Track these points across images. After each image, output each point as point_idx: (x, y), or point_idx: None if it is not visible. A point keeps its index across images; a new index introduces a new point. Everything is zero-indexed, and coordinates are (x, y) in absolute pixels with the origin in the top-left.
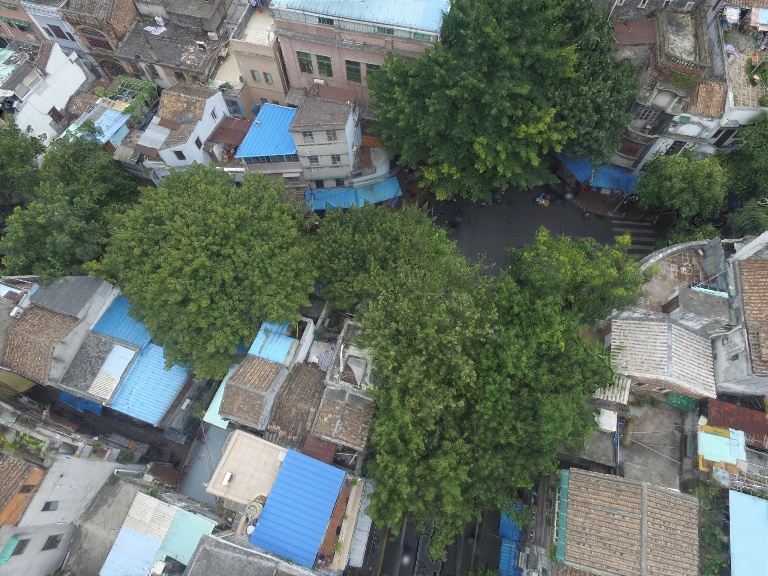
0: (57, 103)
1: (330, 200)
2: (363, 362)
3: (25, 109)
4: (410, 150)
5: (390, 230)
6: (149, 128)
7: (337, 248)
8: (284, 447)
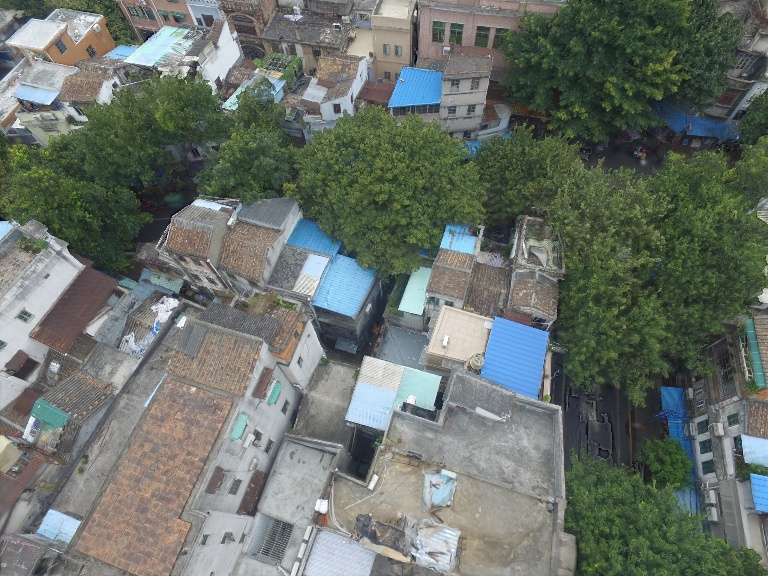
0: (221, 73)
1: None
2: (544, 250)
3: (203, 74)
4: (542, 95)
5: None
6: (310, 87)
7: (506, 163)
8: (488, 317)
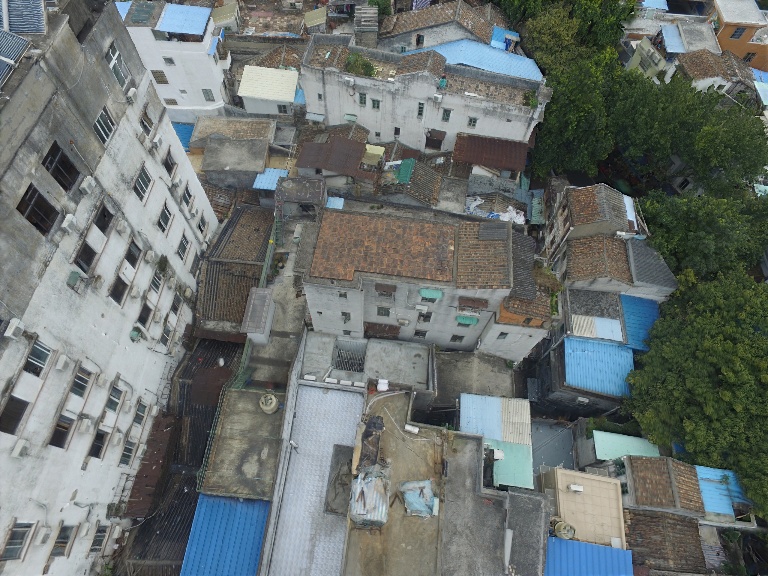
0: None
1: None
2: None
3: None
4: None
5: None
6: None
7: None
8: None
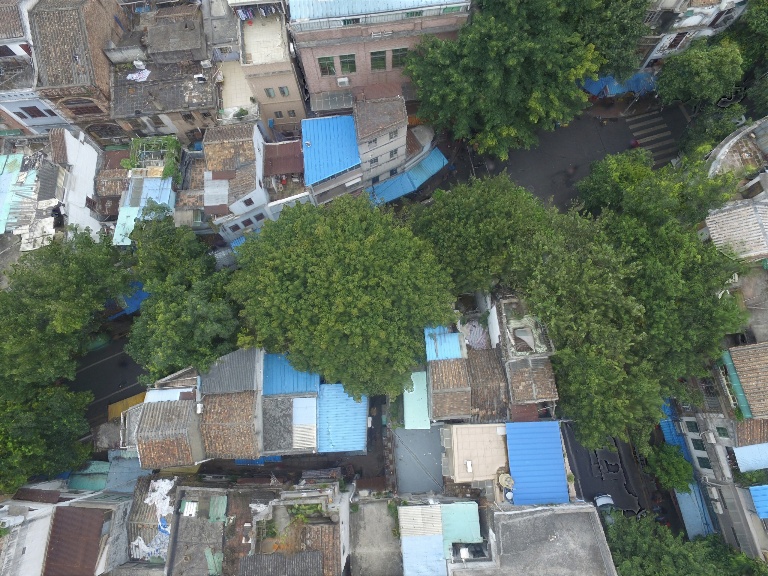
0: (87, 191)
1: (389, 191)
2: (528, 330)
3: (70, 211)
4: (466, 123)
5: None
6: (206, 186)
7: (462, 241)
8: (498, 423)
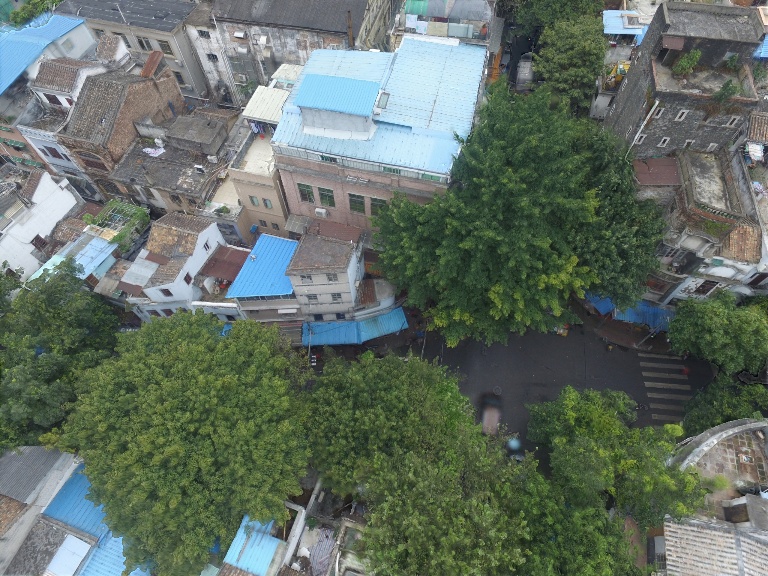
0: (42, 231)
1: (329, 334)
2: None
3: (4, 242)
4: (418, 292)
5: (396, 400)
6: (135, 263)
7: (335, 423)
8: None
